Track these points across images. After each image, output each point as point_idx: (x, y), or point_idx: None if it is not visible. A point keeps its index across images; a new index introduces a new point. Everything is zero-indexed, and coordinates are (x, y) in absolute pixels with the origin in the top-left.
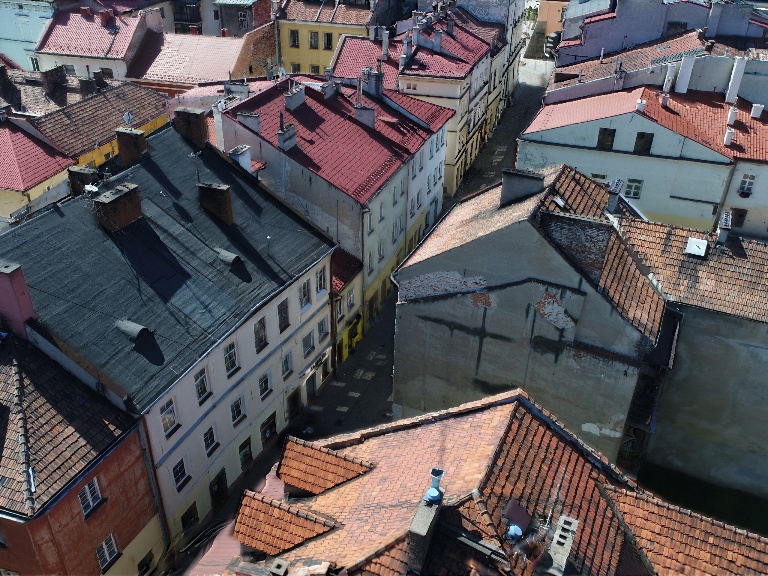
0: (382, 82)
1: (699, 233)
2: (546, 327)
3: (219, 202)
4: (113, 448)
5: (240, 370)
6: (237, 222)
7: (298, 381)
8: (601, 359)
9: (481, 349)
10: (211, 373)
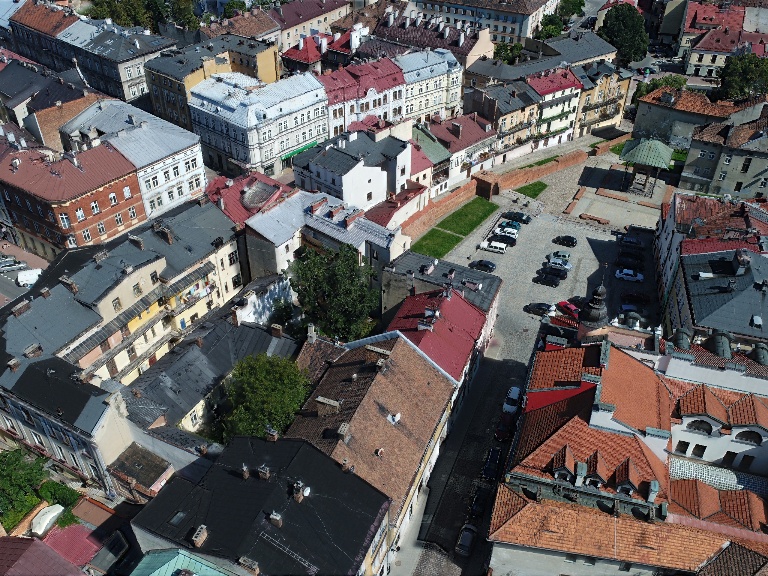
0: None
1: None
2: None
3: None
4: None
5: None
6: None
7: None
8: None
9: None
10: None
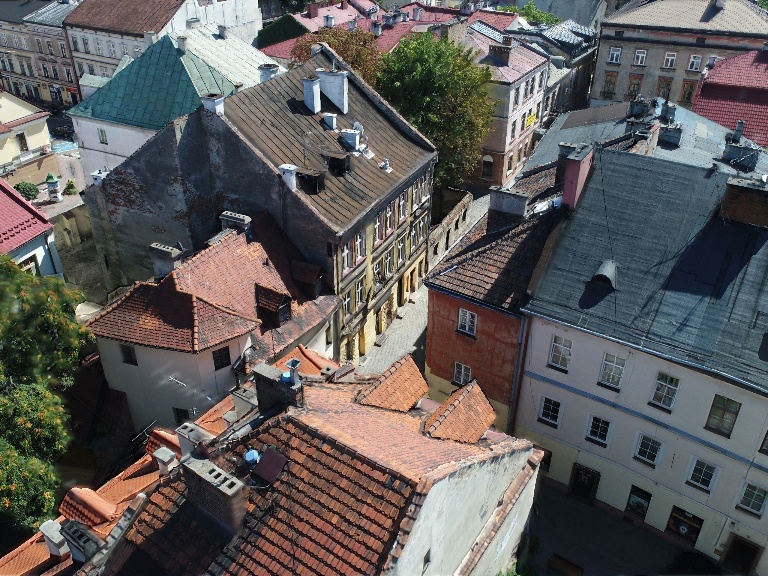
0: None
1: None
2: None
3: None
4: (492, 308)
5: (670, 415)
6: None
7: (765, 540)
8: None
9: None
10: (628, 373)
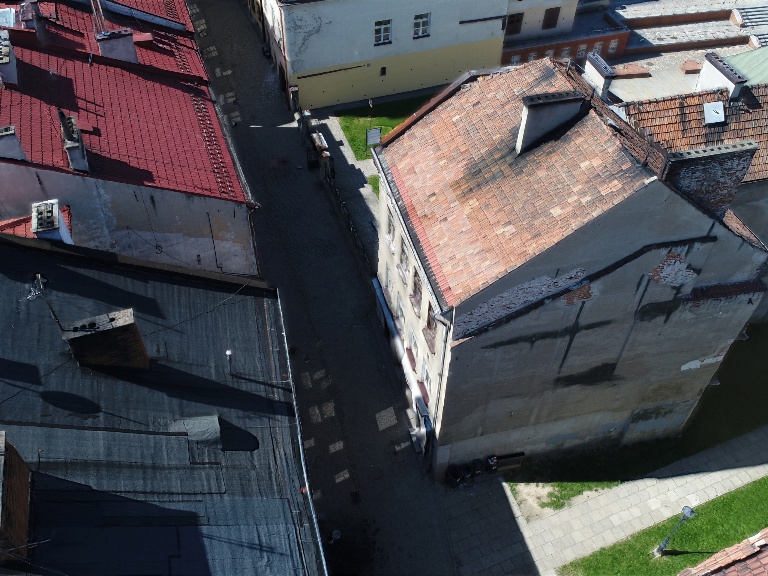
0: None
1: (710, 95)
2: (660, 292)
3: (122, 345)
4: None
5: None
6: (150, 353)
7: None
8: (723, 299)
9: (570, 346)
10: None
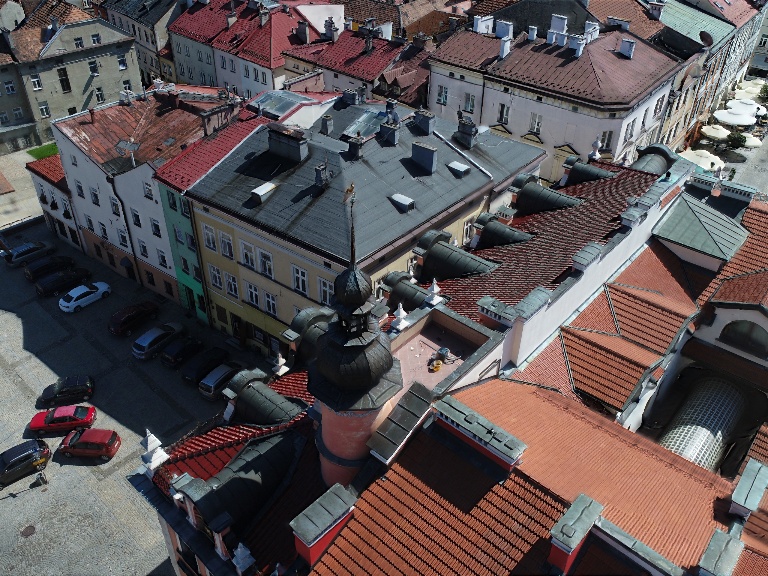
0: (260, 17)
1: None
2: None
3: None
4: None
5: None
6: None
7: None
8: None
9: None
10: None
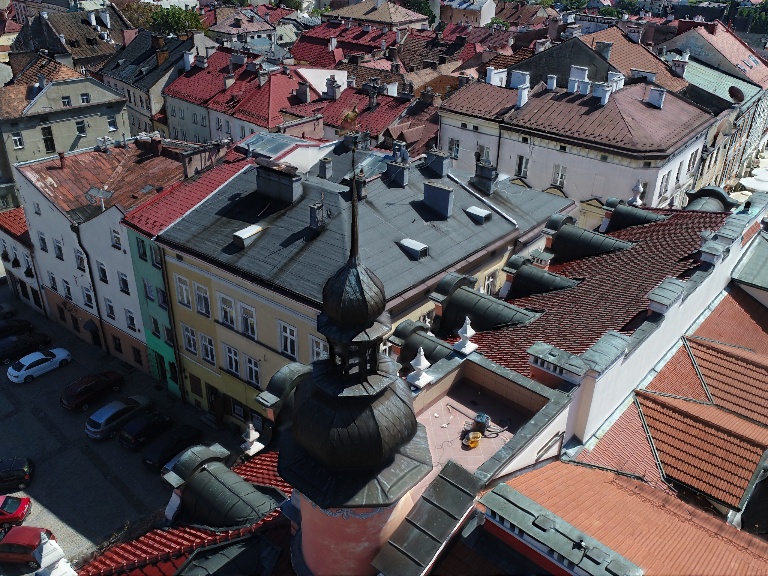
0: (259, 78)
1: None
2: None
3: None
4: None
5: None
6: None
7: None
8: None
9: None
10: None
